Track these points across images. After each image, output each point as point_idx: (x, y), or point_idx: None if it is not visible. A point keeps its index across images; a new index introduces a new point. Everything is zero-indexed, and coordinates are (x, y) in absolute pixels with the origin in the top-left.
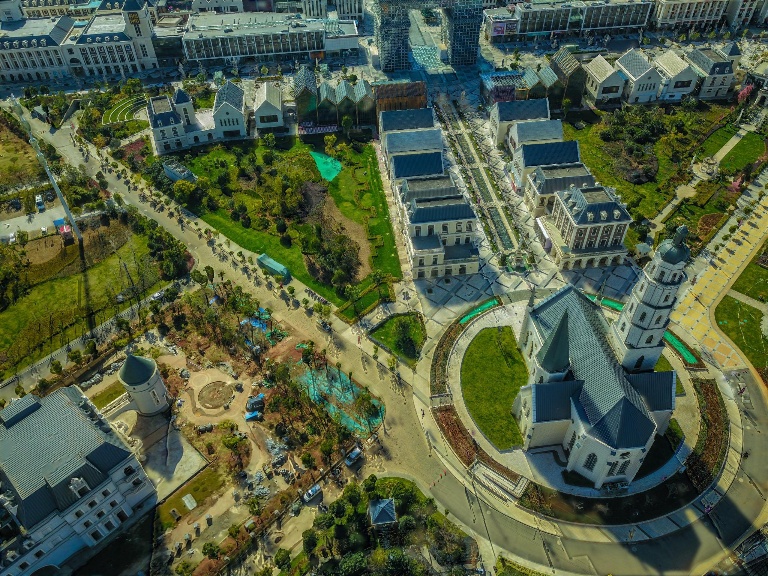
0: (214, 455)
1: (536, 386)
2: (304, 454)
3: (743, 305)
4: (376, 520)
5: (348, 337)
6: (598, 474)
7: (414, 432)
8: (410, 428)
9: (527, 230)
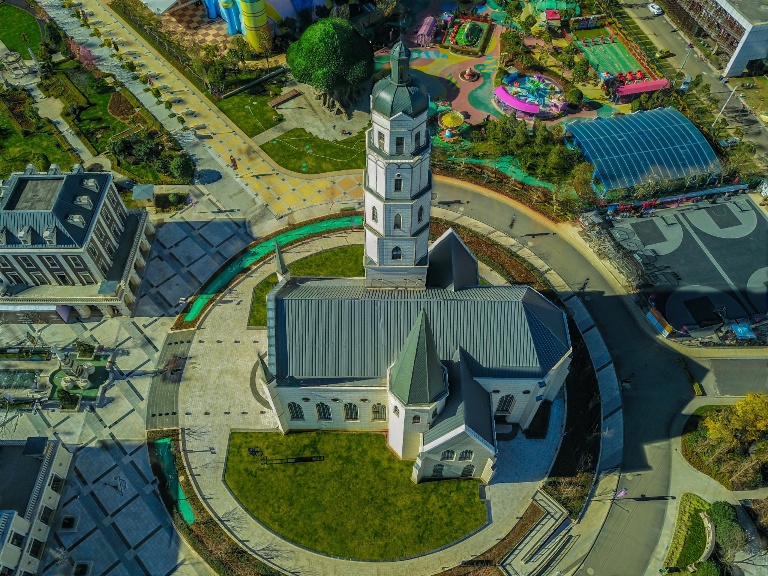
0: None
1: (465, 424)
2: None
3: (283, 138)
4: None
5: None
6: (550, 389)
7: None
8: None
9: (4, 335)
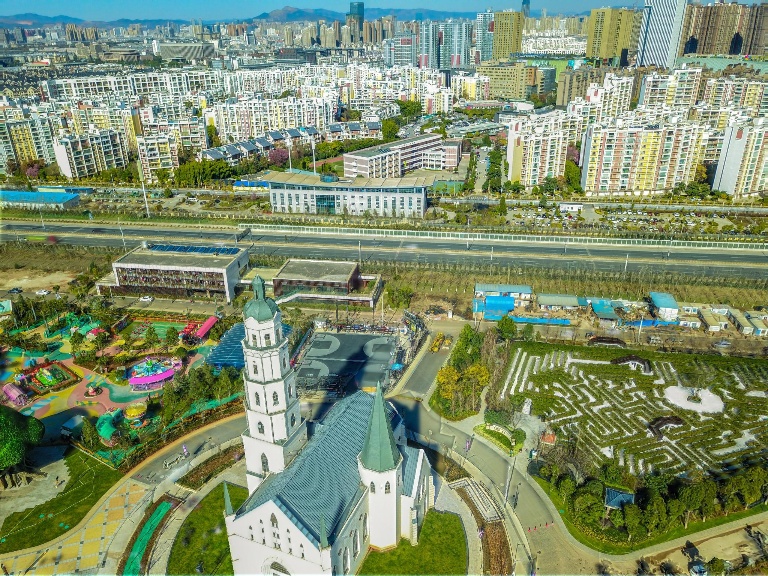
0: None
1: None
2: (721, 568)
3: (8, 532)
4: (629, 494)
5: None
6: None
7: None
8: None
9: None
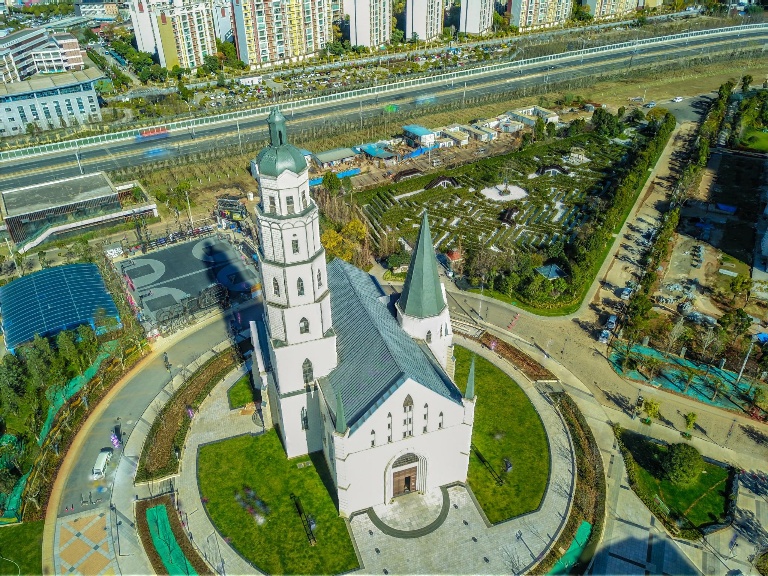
0: (753, 302)
1: None
2: None
3: None
4: None
5: (761, 462)
6: None
7: (564, 355)
8: (571, 358)
9: None
